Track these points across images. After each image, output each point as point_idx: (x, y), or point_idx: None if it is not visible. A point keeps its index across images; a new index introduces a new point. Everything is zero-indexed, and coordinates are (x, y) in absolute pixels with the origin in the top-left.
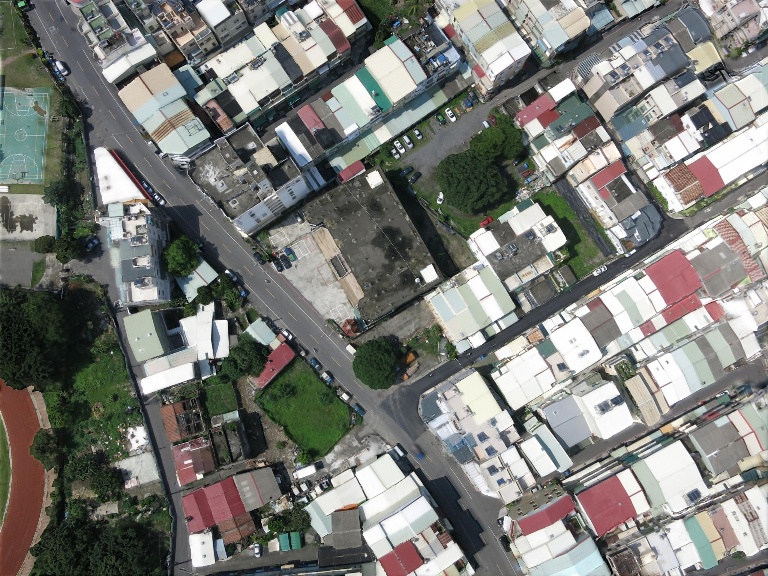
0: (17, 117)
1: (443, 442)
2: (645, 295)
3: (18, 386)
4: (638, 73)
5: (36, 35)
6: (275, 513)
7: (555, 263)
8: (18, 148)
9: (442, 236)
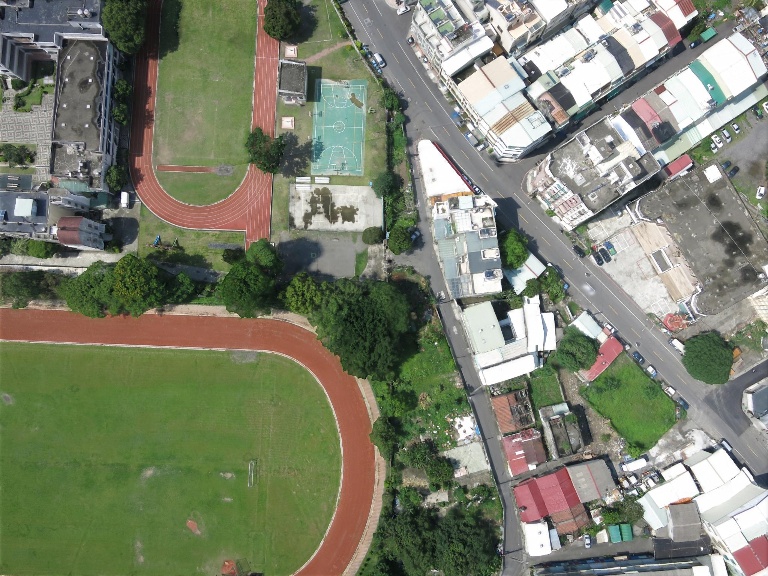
0: (335, 109)
1: (767, 438)
2: None
3: (363, 375)
4: None
5: (351, 27)
6: (602, 505)
7: None
8: (337, 140)
9: (762, 231)
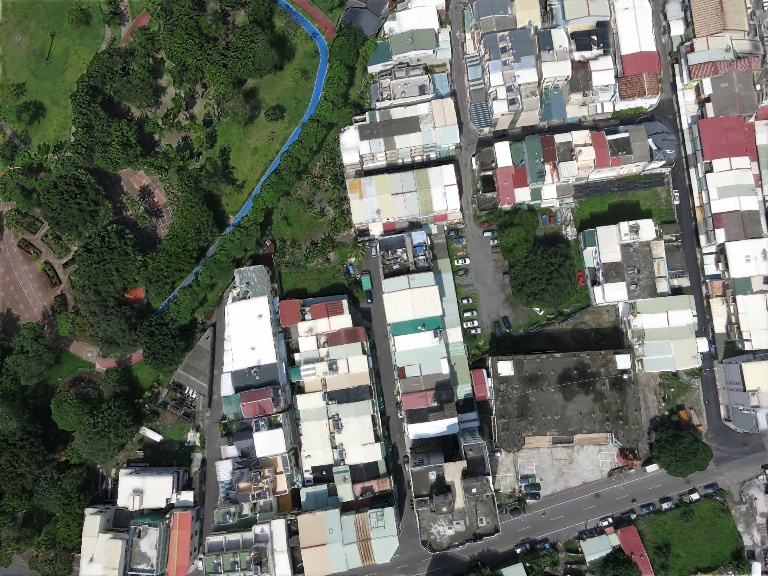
0: None
1: None
2: (731, 172)
3: None
4: (520, 79)
5: None
6: None
7: (661, 238)
8: None
9: (575, 326)
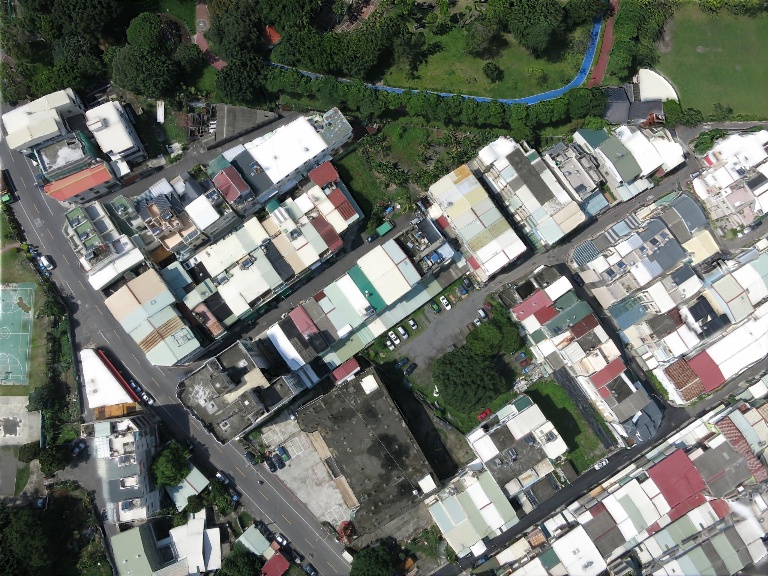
0: (1, 314)
1: None
2: (649, 500)
3: None
4: (635, 270)
5: (21, 228)
6: None
7: (556, 466)
8: (2, 347)
9: (439, 430)
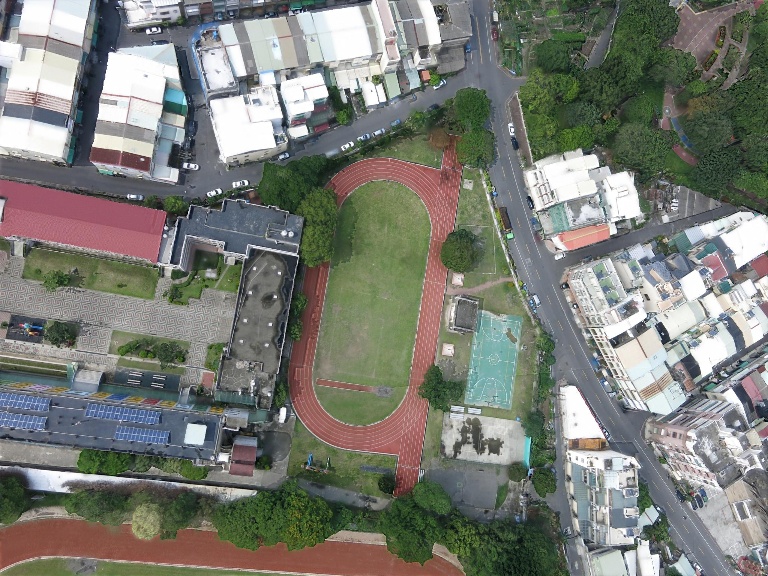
0: (492, 341)
1: None
2: None
3: None
4: None
5: None
6: None
7: None
8: (491, 372)
9: None
